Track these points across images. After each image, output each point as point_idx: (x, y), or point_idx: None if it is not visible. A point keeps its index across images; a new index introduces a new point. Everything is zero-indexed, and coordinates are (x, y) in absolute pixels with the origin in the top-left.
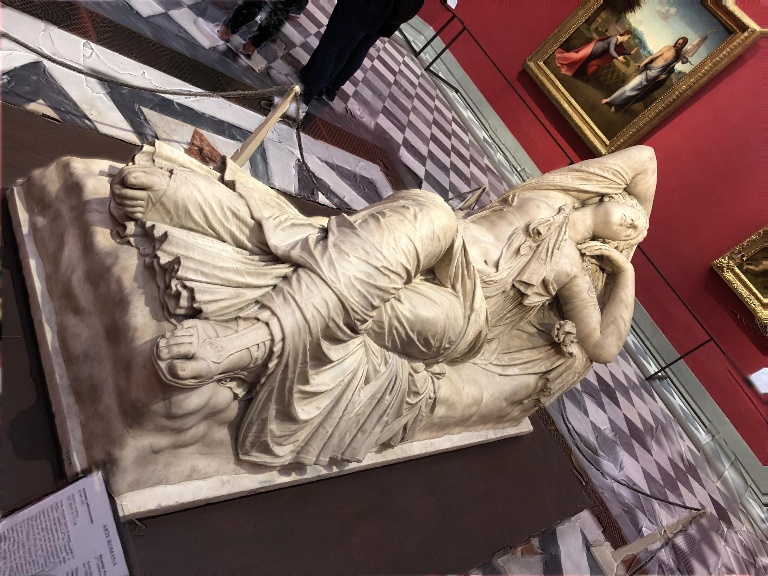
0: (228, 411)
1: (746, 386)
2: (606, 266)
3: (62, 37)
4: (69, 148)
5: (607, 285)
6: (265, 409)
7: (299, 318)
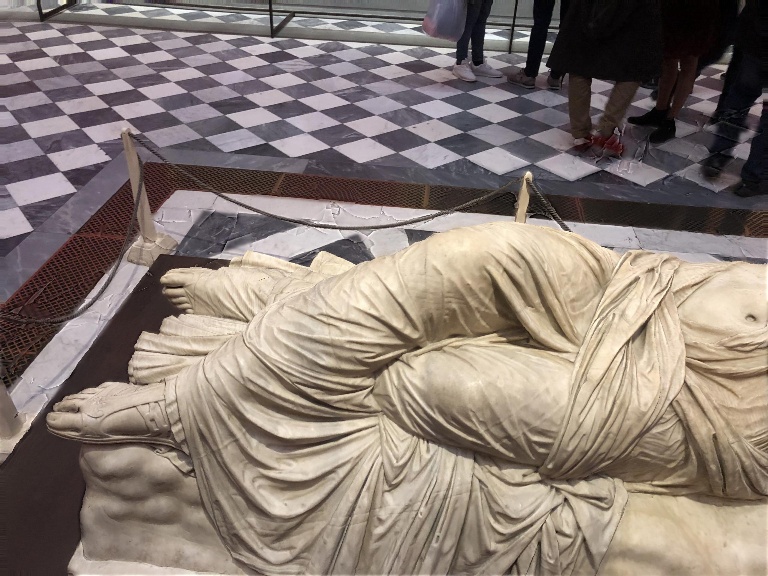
0: (185, 488)
1: None
2: None
3: (390, 212)
4: None
5: None
6: (209, 489)
7: (201, 378)
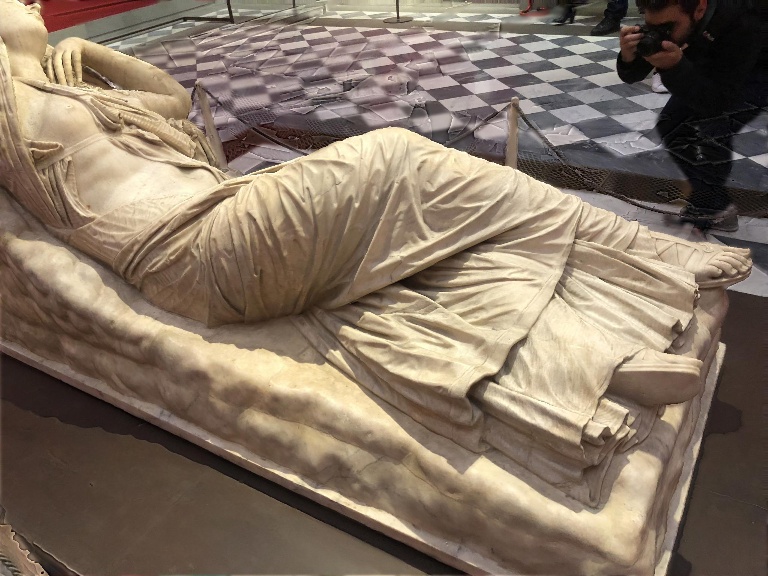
0: None
1: (88, 4)
2: None
3: None
4: None
5: (83, 79)
6: None
7: None
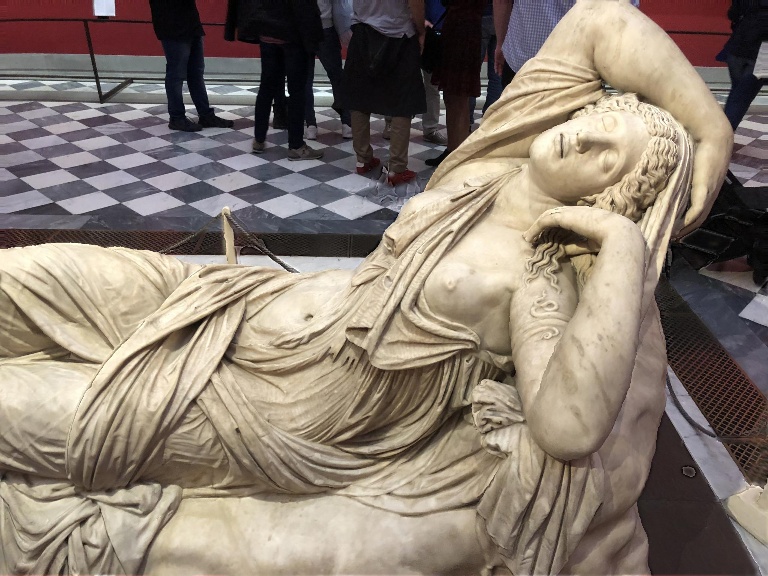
0: None
1: None
2: (593, 247)
3: None
4: None
5: None
6: None
7: None
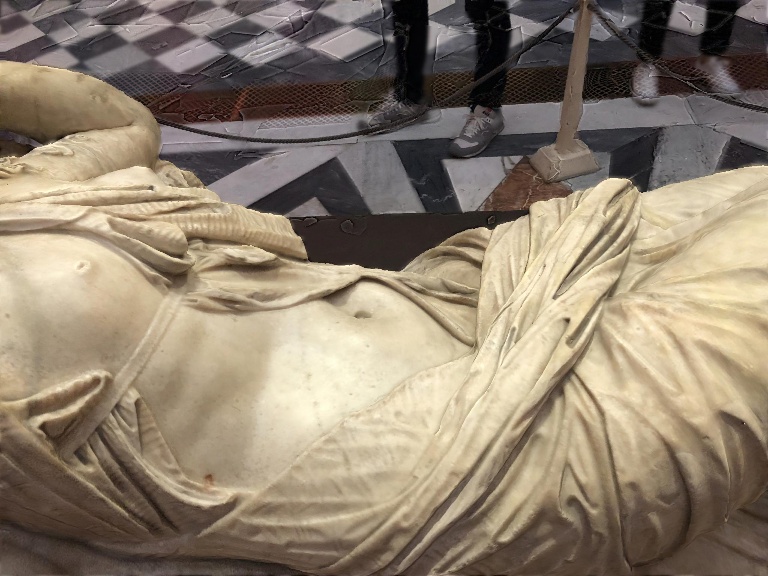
0: None
1: None
2: None
3: None
4: None
5: None
6: None
7: None
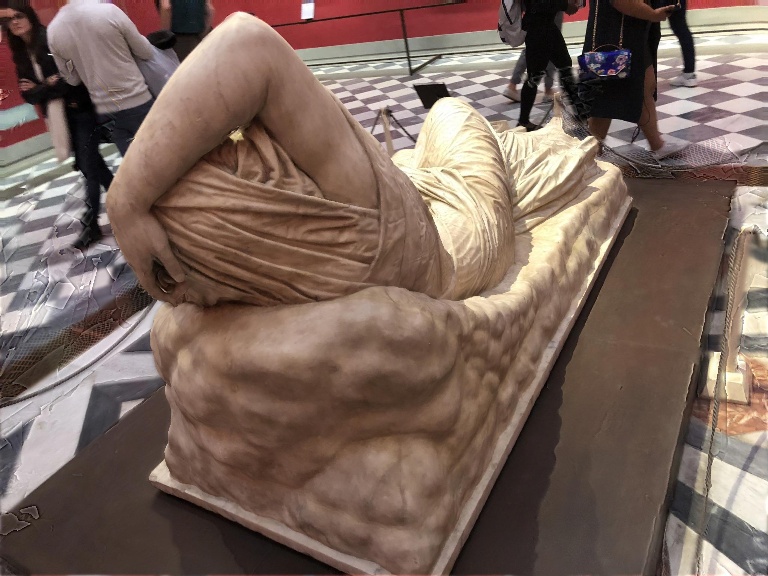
0: None
1: None
2: None
3: None
4: (691, 237)
5: None
6: None
7: None
